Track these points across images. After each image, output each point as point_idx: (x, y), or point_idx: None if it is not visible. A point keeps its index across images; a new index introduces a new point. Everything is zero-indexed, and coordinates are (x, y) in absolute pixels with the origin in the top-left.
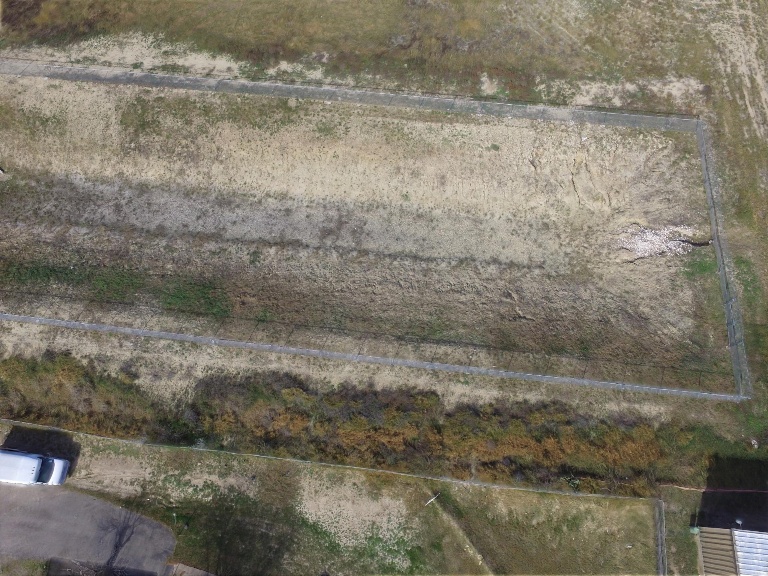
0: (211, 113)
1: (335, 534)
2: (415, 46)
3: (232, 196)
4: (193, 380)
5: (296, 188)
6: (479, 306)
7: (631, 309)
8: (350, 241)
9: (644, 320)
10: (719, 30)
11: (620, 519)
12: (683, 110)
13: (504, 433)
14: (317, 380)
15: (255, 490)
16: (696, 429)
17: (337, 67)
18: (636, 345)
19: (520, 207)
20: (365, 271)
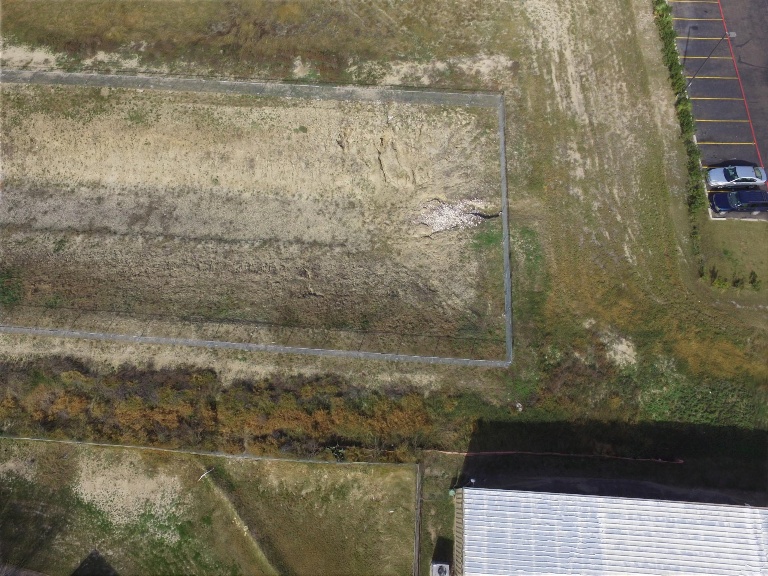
0: (25, 105)
1: (108, 513)
2: (233, 32)
3: (45, 187)
4: None
5: (109, 176)
6: (272, 285)
7: (421, 282)
8: (158, 227)
9: (431, 292)
10: (535, 7)
11: (384, 485)
12: (489, 86)
13: (276, 407)
14: (98, 363)
15: (33, 473)
16: (463, 395)
17: (153, 55)
18: (417, 316)
19: (327, 187)
20: (167, 255)
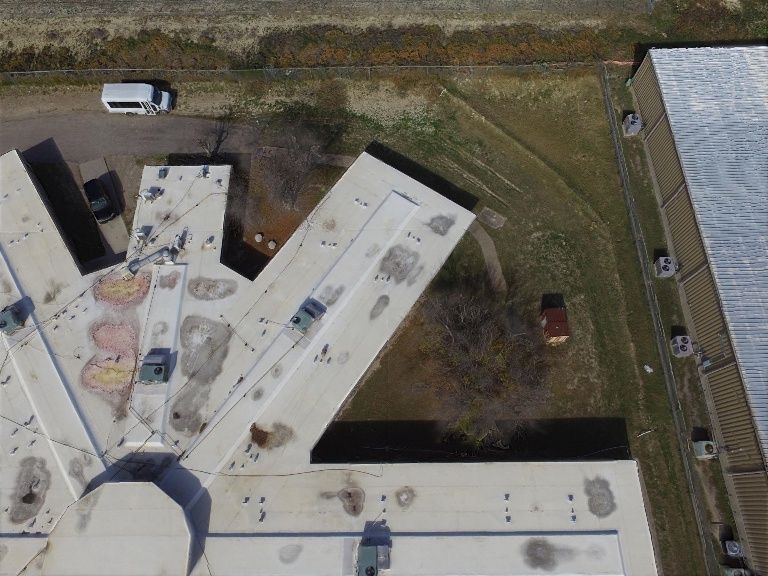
0: None
1: (377, 119)
2: None
3: None
4: (257, 38)
5: None
6: None
7: None
8: None
9: None
10: None
11: (577, 86)
12: None
13: (490, 43)
14: (350, 27)
15: (314, 101)
16: (623, 30)
17: None
18: None
19: None
20: None
